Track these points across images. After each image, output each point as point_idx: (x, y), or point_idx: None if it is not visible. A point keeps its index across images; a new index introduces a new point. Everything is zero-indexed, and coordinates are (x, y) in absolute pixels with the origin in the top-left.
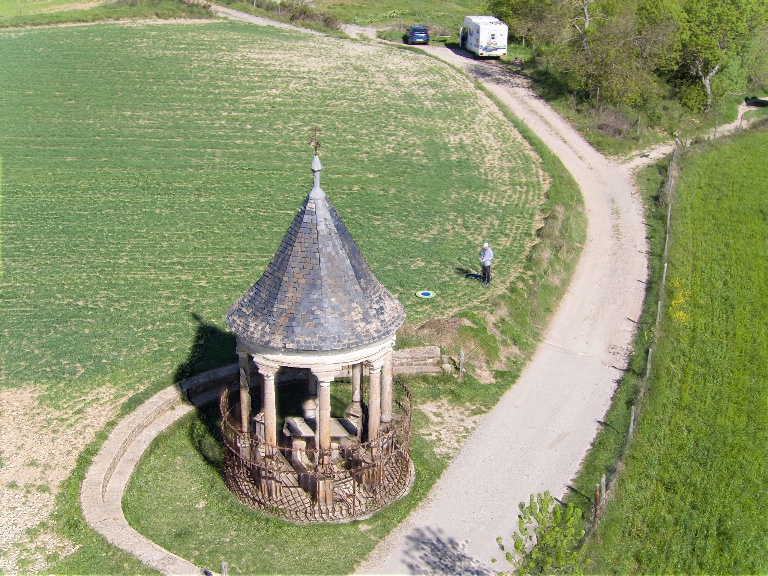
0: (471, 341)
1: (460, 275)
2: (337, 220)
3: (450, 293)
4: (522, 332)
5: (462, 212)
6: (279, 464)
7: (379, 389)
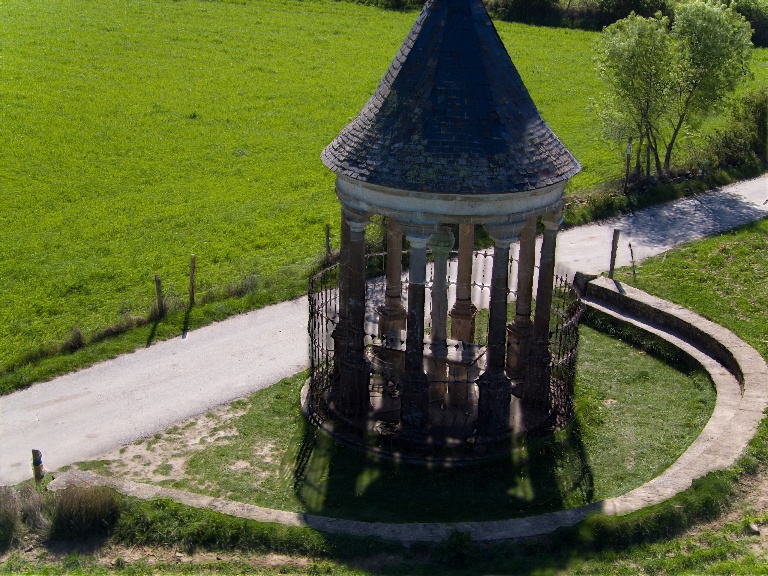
0: None
1: None
2: None
3: None
4: None
5: None
6: None
7: None
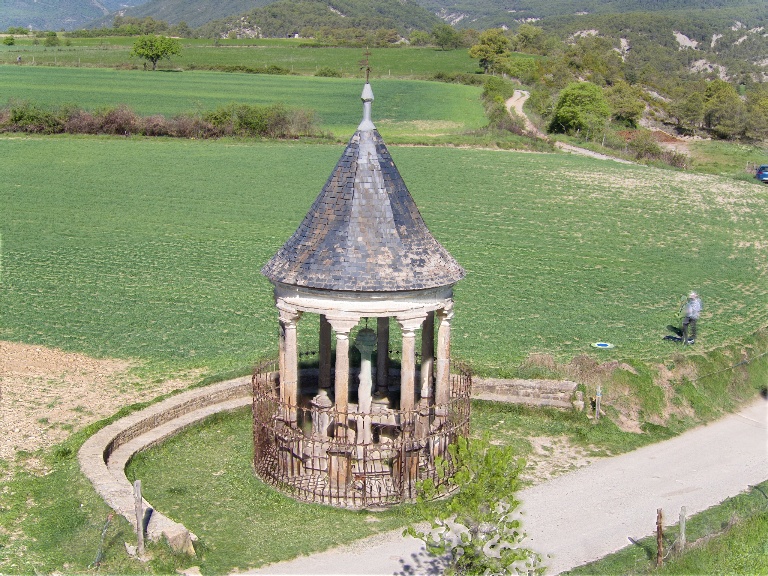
0: (625, 387)
1: (658, 337)
2: (385, 158)
3: (633, 348)
4: (710, 399)
5: (705, 294)
6: (298, 435)
7: (413, 358)
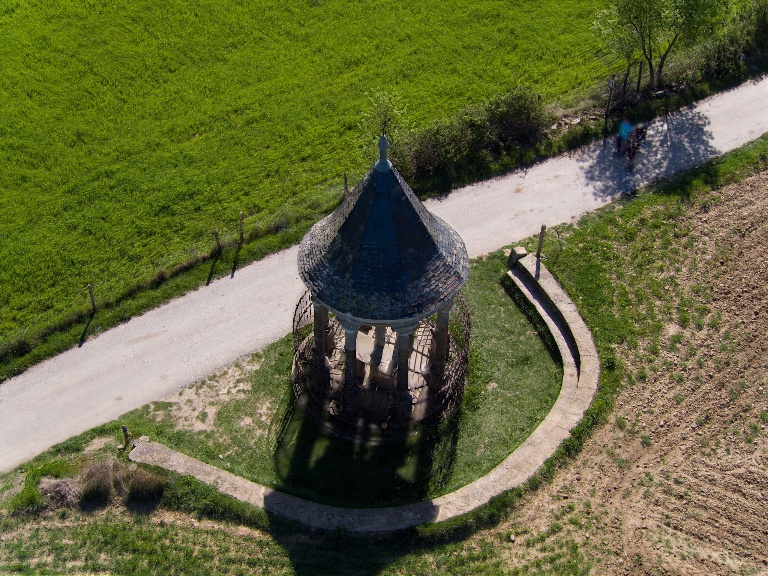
0: None
1: None
2: None
3: None
4: None
5: None
6: None
7: None
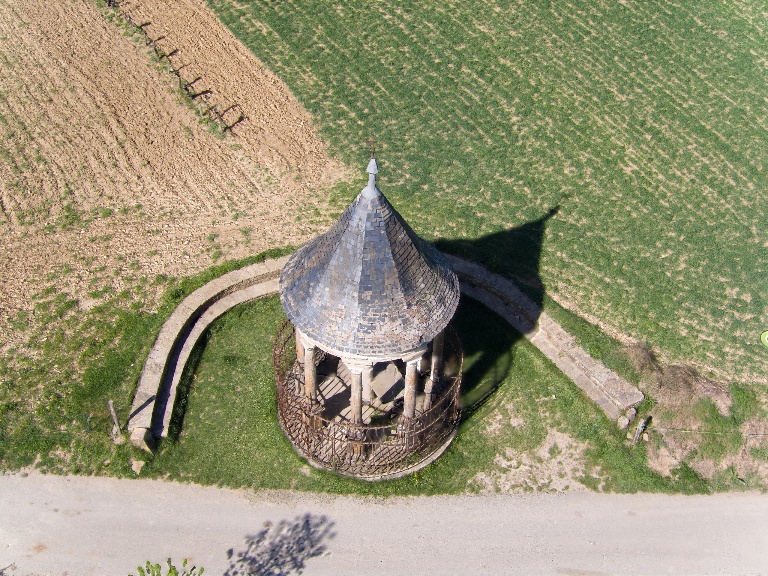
0: (698, 421)
1: None
2: (376, 226)
3: None
4: None
5: None
6: None
7: (358, 386)
